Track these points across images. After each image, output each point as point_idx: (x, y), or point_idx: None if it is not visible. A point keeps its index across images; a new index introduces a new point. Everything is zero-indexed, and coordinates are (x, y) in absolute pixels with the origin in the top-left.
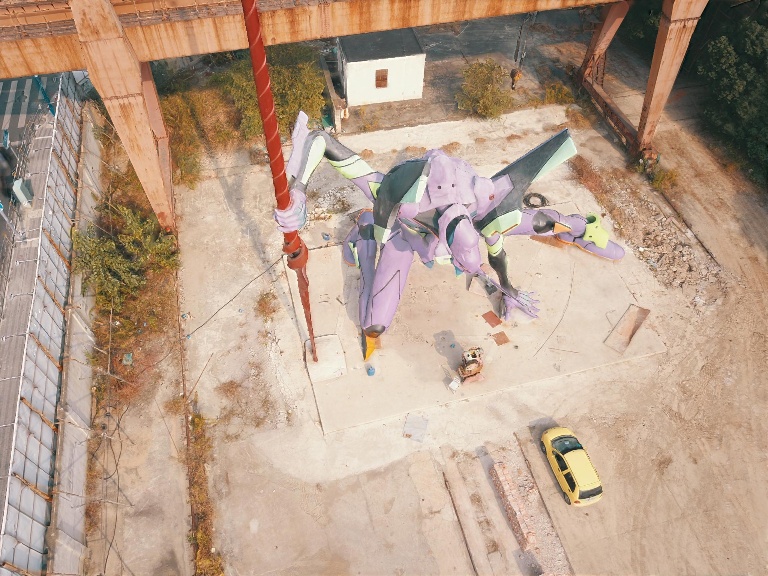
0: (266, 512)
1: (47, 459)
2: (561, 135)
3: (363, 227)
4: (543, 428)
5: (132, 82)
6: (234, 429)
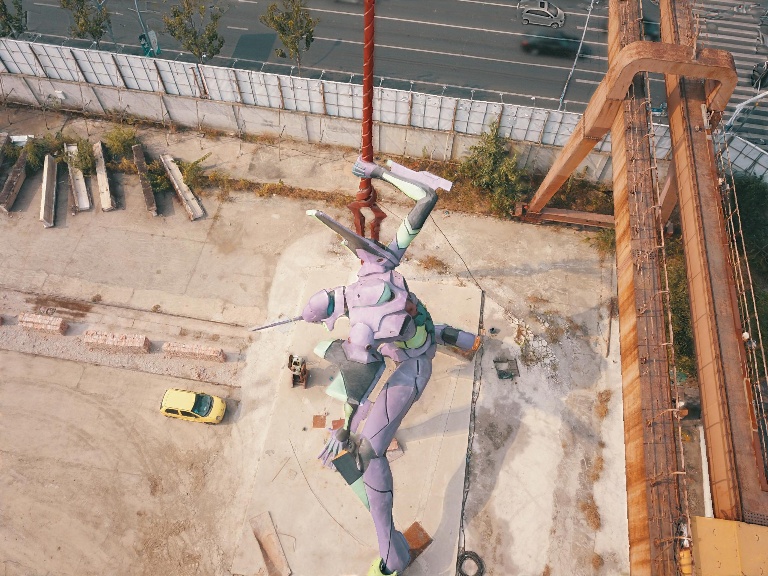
0: (280, 224)
1: (347, 114)
2: (358, 397)
3: (459, 331)
4: (232, 411)
5: (589, 125)
6: (342, 221)
